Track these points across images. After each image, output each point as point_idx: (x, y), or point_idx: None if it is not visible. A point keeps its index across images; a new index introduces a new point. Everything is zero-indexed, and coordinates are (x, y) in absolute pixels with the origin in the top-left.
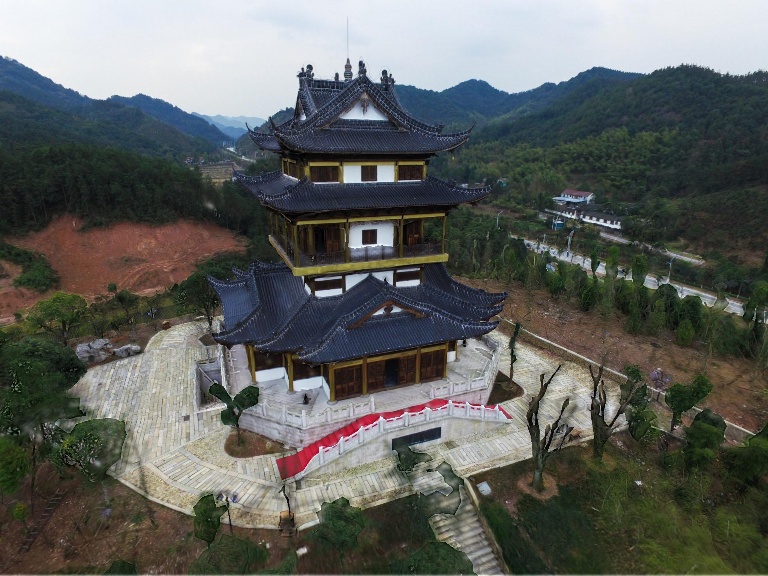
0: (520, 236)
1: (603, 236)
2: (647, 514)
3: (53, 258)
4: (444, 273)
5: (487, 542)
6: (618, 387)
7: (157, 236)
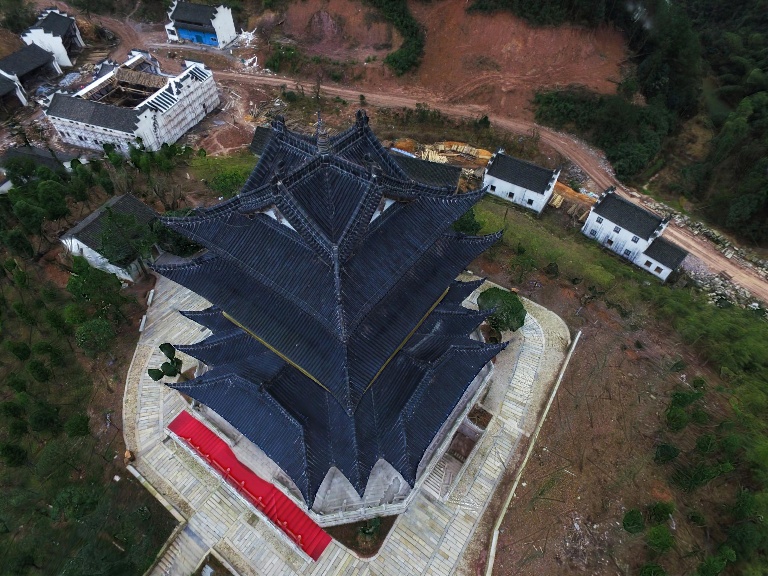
0: None
1: None
2: None
3: (431, 37)
4: (410, 395)
5: None
6: None
7: (528, 40)
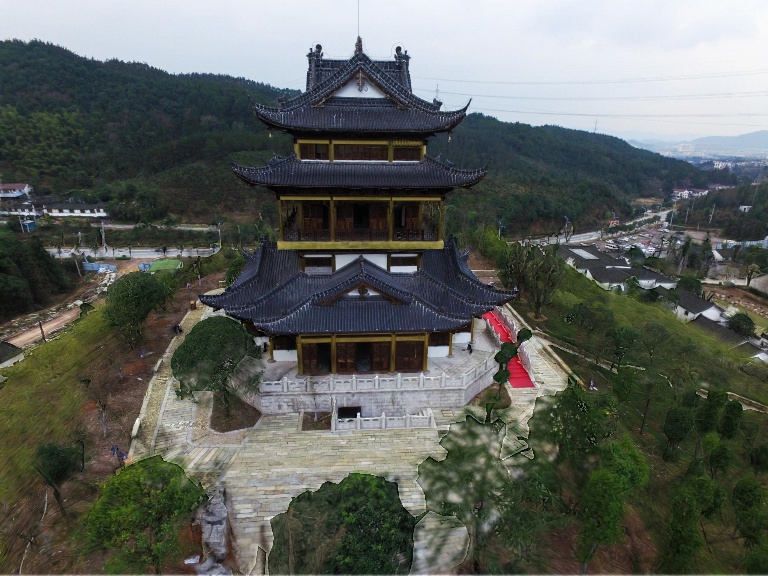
0: None
1: (95, 226)
2: (564, 298)
3: None
4: None
5: (562, 347)
6: None
7: None
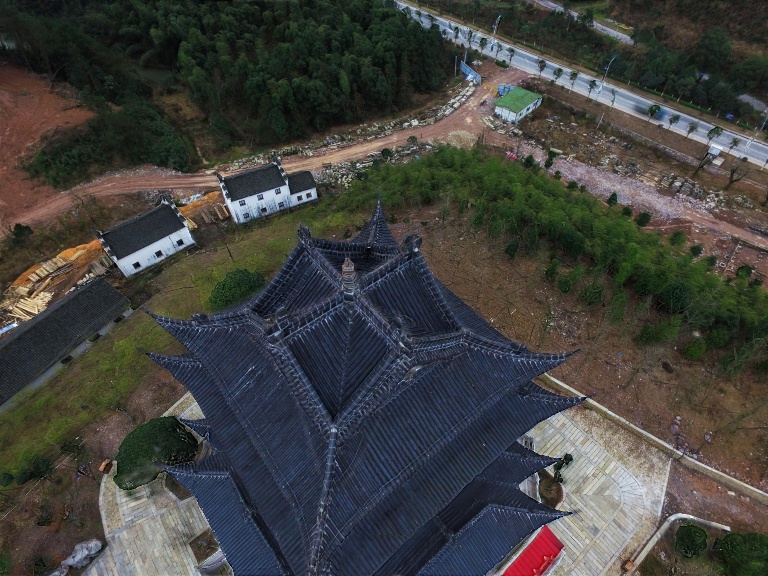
0: (430, 10)
1: None
2: None
3: None
4: None
5: None
6: (641, 446)
7: None
